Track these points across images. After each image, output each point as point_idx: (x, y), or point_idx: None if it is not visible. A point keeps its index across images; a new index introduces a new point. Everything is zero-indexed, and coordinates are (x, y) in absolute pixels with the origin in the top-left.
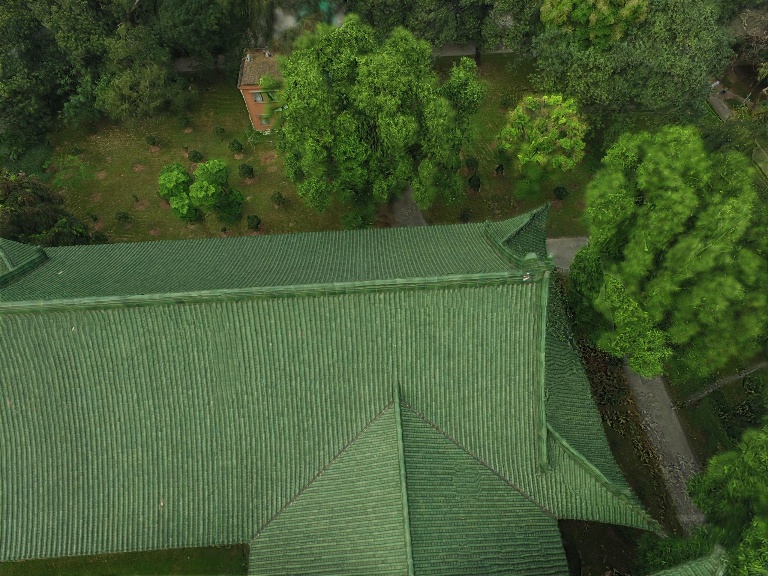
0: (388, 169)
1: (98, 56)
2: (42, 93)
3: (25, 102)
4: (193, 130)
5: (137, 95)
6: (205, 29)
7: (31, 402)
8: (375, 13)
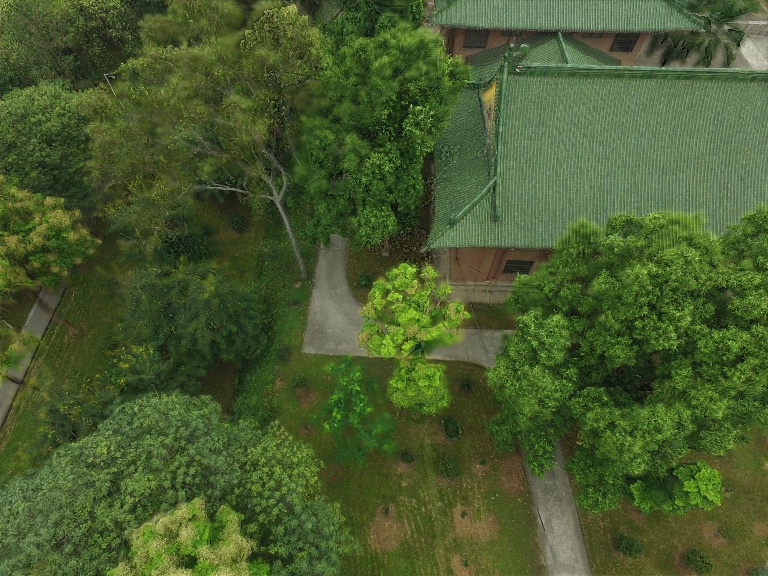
0: None
1: None
2: None
3: None
4: None
5: None
6: None
7: None
8: None
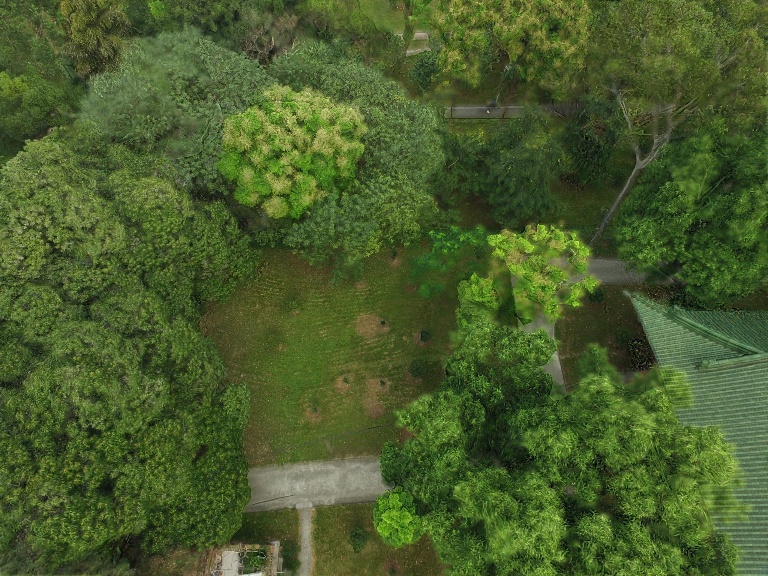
0: None
1: None
2: None
3: None
4: None
5: None
6: None
7: None
8: None
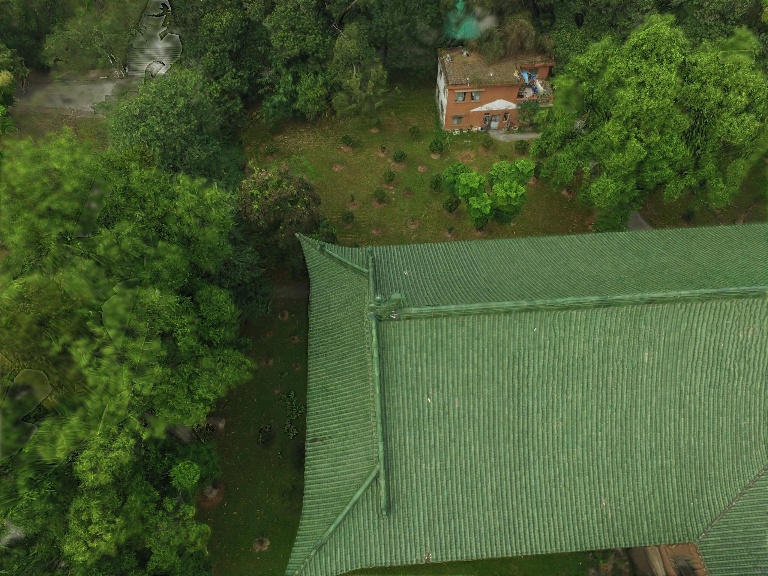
0: (688, 169)
1: (306, 56)
2: (243, 93)
3: (231, 102)
4: (380, 130)
5: (365, 95)
6: (418, 29)
7: (480, 402)
8: (591, 13)
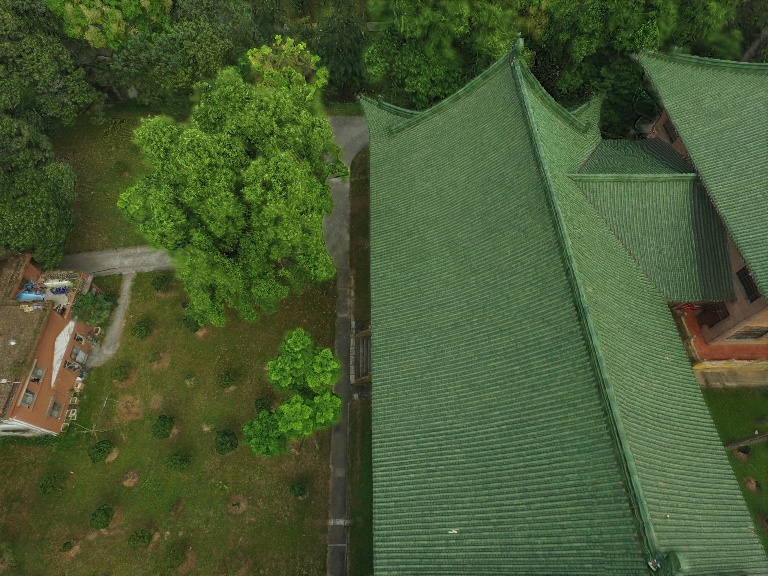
0: None
1: None
2: None
3: None
4: None
5: None
6: None
7: None
8: None
